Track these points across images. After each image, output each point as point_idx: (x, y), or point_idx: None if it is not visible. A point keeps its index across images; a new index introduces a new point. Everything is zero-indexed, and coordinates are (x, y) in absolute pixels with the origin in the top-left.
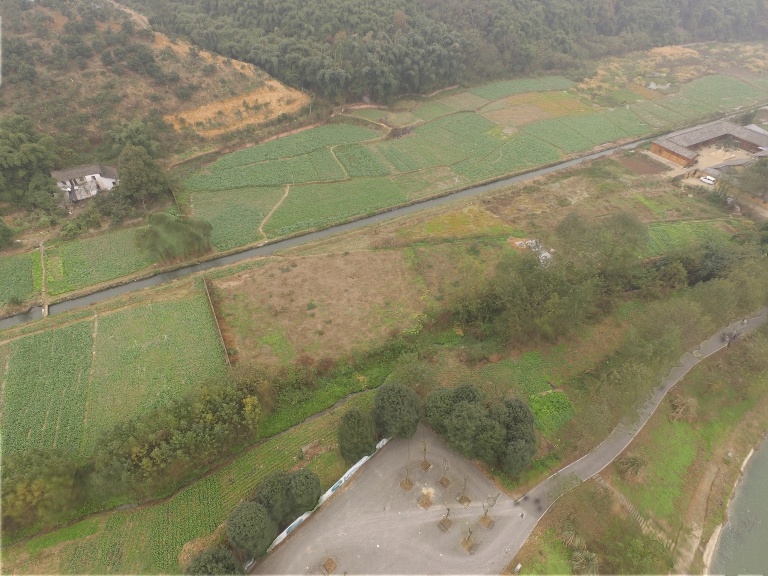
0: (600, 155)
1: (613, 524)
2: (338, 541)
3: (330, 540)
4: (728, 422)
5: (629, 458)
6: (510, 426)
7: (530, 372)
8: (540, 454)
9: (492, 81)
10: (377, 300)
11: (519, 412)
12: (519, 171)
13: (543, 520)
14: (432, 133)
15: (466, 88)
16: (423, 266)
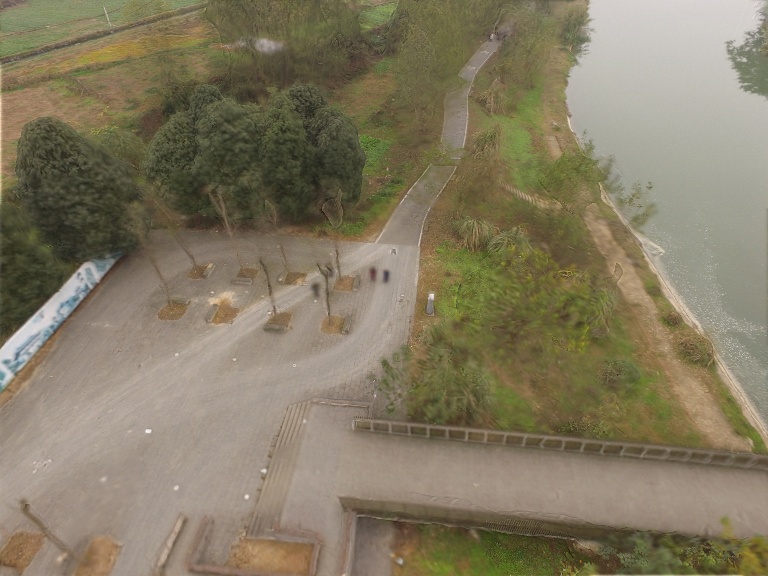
0: None
1: (506, 208)
2: (31, 485)
3: (5, 497)
4: (534, 105)
5: (477, 138)
6: (307, 124)
7: None
8: (373, 190)
9: None
10: (13, 136)
11: (310, 97)
12: (194, 4)
13: (424, 242)
14: (55, 2)
15: None
16: (89, 88)
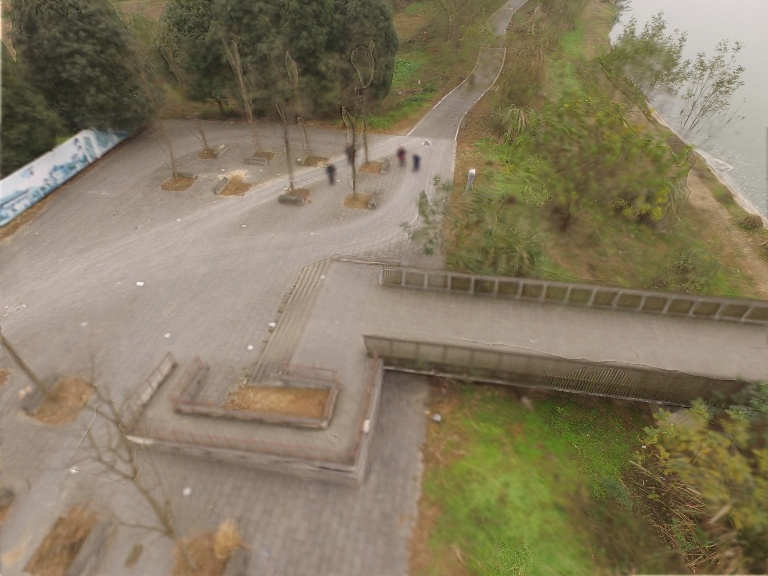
0: None
1: None
2: None
3: None
4: (576, 43)
5: None
6: None
7: None
8: (403, 98)
9: None
10: None
11: None
12: None
13: (461, 137)
14: None
15: None
16: None
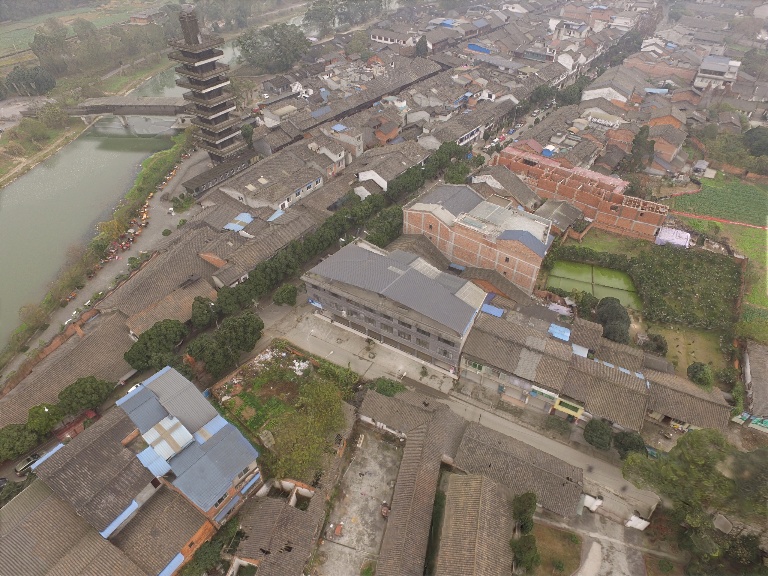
0: (104, 28)
1: None
2: None
3: None
4: None
5: None
6: None
7: (63, 81)
8: None
9: (37, 16)
10: None
11: (39, 68)
12: None
13: None
14: None
15: (17, 21)
16: (2, 71)
